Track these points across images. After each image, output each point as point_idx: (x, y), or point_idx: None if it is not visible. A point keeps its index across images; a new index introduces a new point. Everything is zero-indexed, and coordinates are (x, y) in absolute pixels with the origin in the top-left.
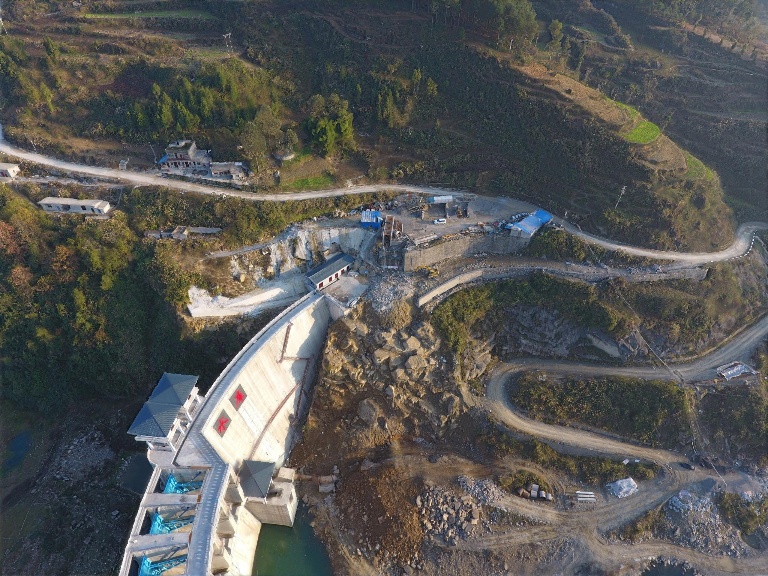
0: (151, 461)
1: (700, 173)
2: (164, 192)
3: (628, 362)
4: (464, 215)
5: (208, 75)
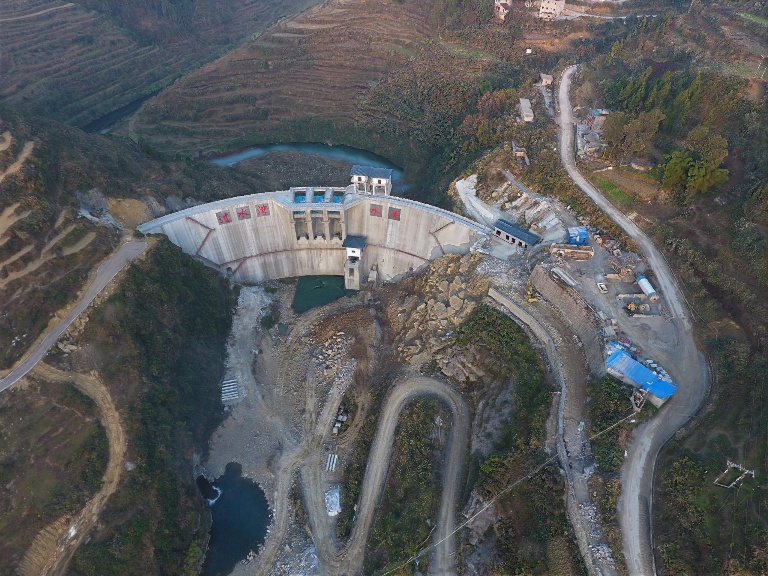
0: (349, 186)
1: None
2: (550, 128)
3: (460, 517)
4: (632, 313)
5: None
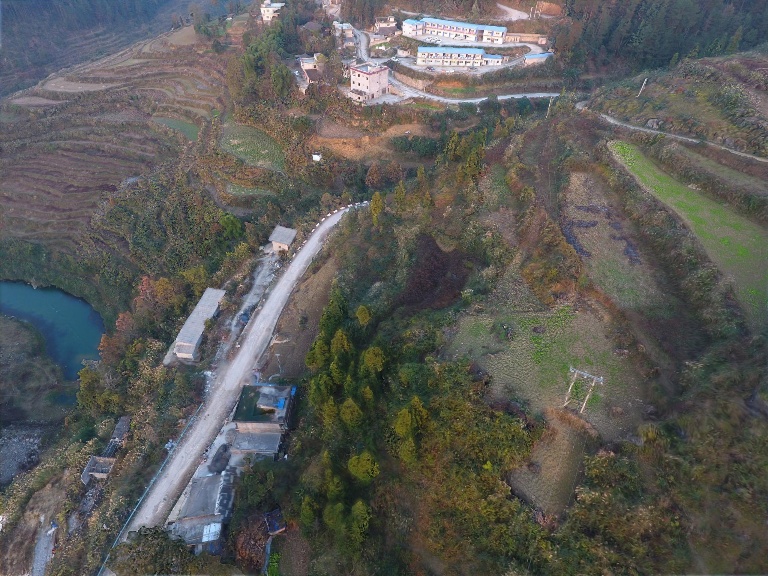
0: None
1: None
2: (174, 416)
3: None
4: None
5: (428, 385)
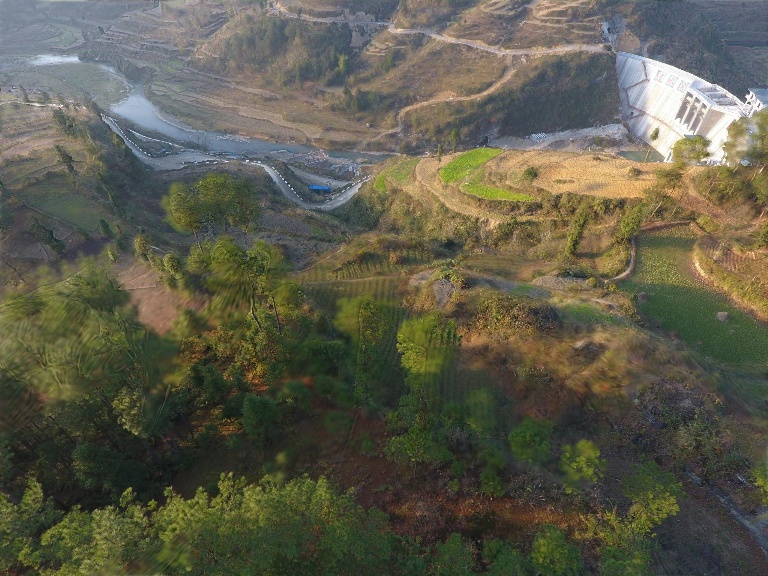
0: None
1: (403, 164)
2: None
3: None
4: None
5: None
